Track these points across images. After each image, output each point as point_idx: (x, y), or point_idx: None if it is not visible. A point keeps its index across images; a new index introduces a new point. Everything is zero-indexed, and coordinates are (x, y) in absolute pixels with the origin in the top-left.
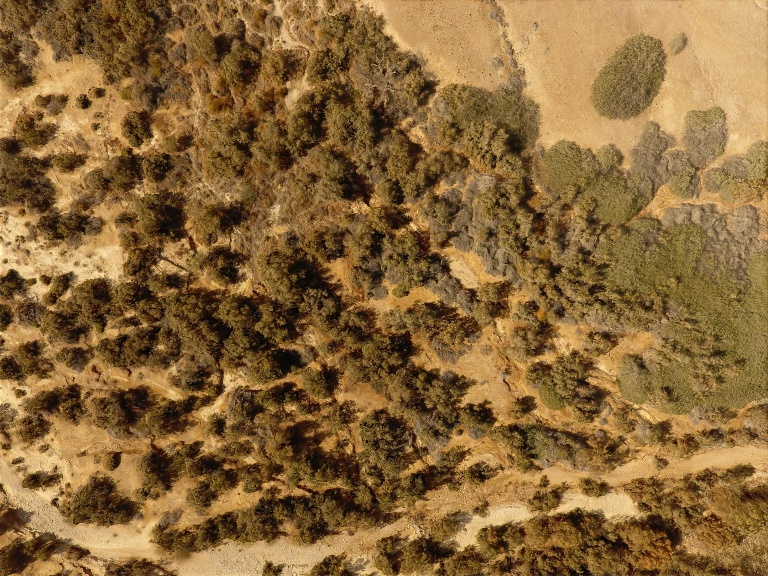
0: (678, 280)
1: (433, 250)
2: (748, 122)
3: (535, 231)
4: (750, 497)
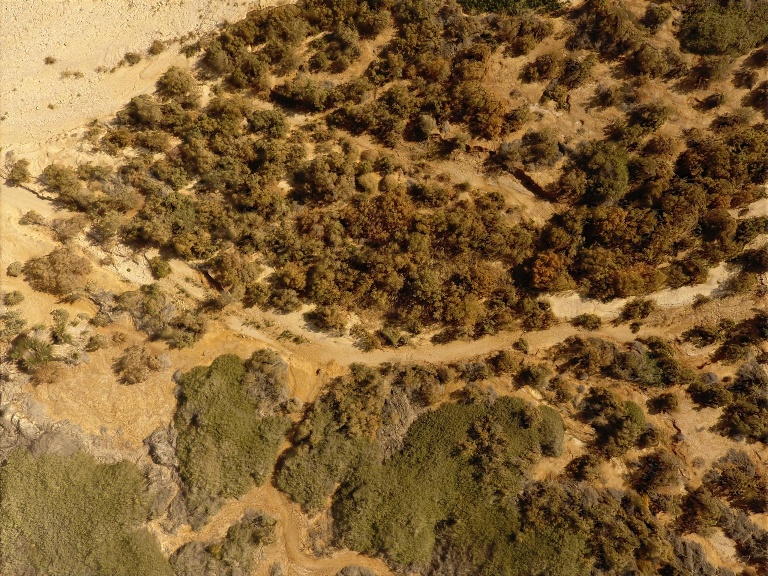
0: (514, 539)
1: (754, 569)
2: None
3: None
4: (444, 318)
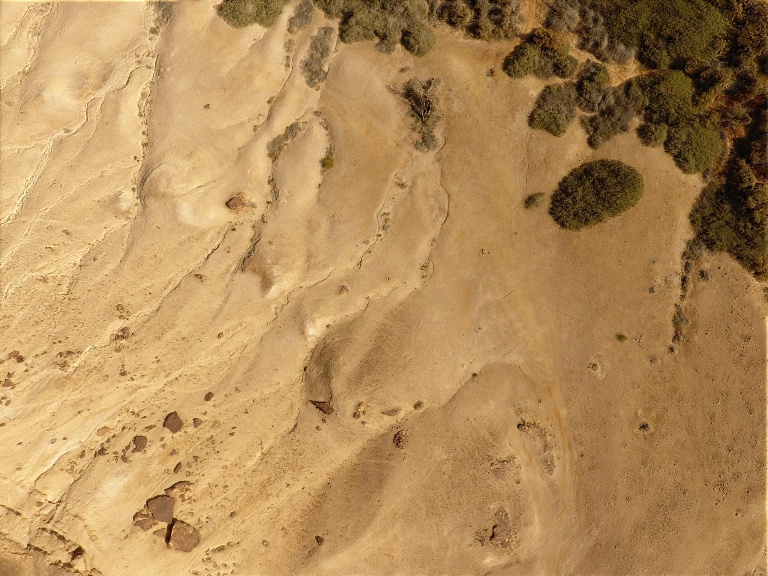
0: None
1: None
2: (514, 99)
3: (756, 105)
4: None
